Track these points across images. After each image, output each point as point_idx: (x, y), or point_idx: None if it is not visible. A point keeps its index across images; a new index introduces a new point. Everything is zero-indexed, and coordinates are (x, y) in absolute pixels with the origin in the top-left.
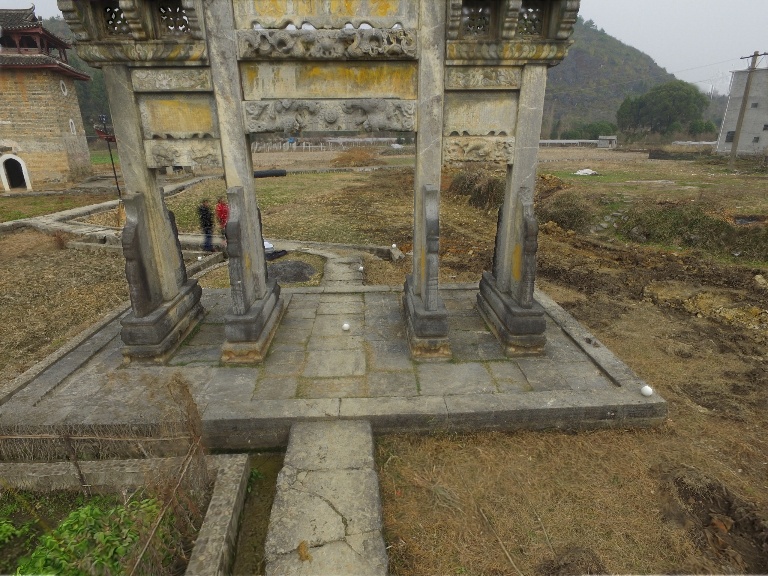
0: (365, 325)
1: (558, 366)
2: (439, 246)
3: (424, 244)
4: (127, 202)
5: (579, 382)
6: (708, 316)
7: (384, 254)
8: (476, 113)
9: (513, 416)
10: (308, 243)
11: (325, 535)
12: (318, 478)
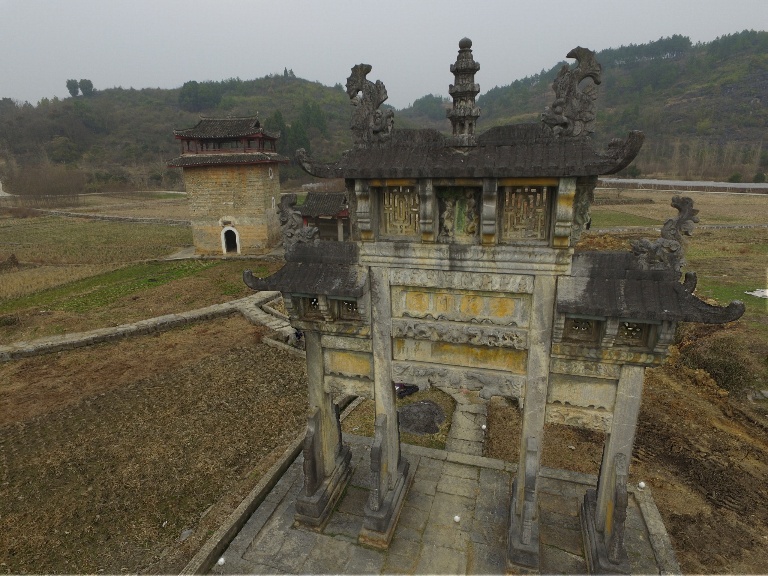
0: (474, 518)
1: None
2: None
3: None
4: (309, 418)
5: None
6: None
7: None
8: (577, 390)
9: None
10: None
11: None
12: None
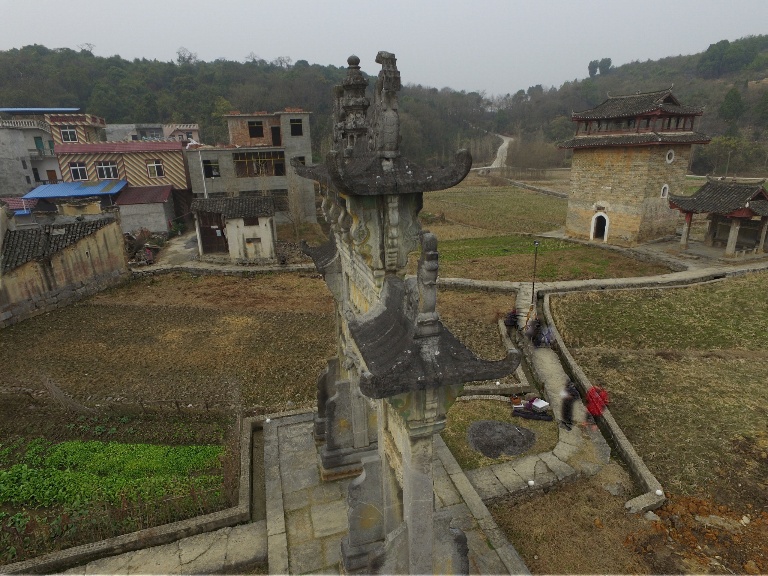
0: None
1: None
2: (759, 547)
3: None
4: None
5: None
6: None
7: (647, 492)
8: None
9: None
10: (594, 422)
11: (184, 556)
12: (222, 544)
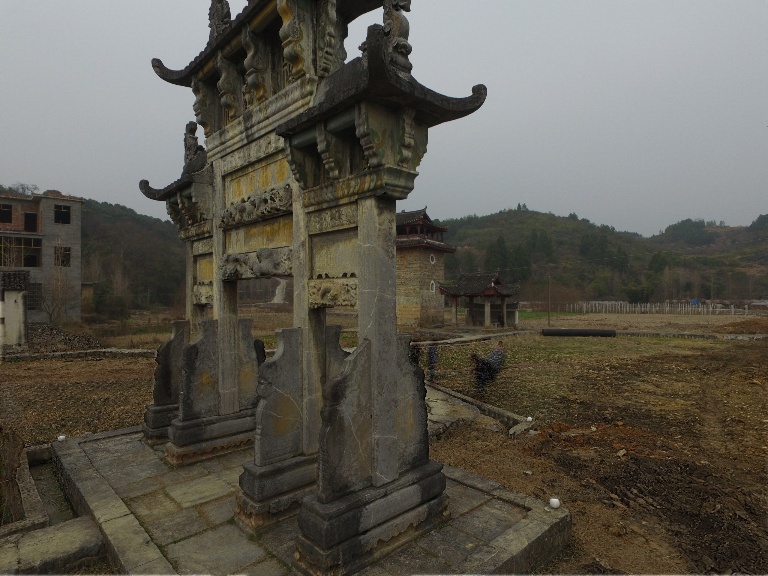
0: None
1: None
2: None
3: None
4: None
5: None
6: None
7: None
8: (333, 255)
9: None
10: (453, 397)
11: None
12: (6, 553)
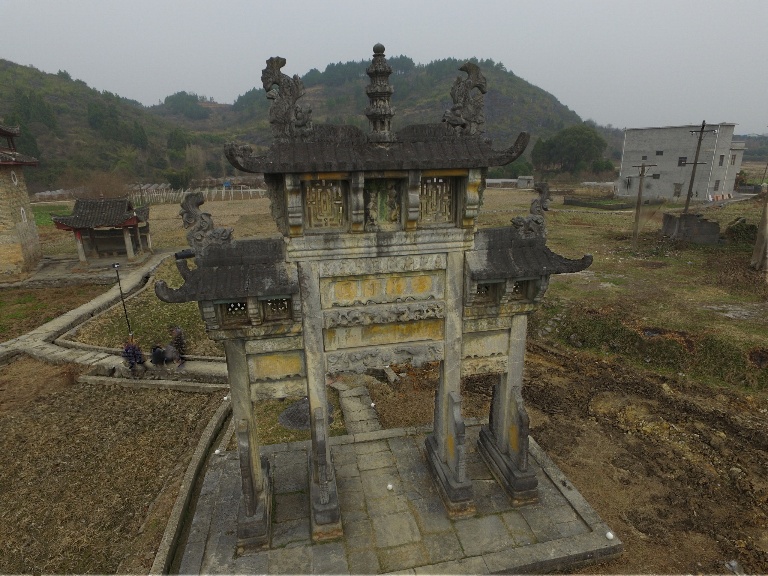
0: (402, 481)
1: (549, 513)
2: None
3: (452, 435)
4: (241, 433)
5: (565, 528)
6: (635, 433)
7: (379, 373)
8: (482, 344)
9: (530, 567)
10: None
11: None
12: None
